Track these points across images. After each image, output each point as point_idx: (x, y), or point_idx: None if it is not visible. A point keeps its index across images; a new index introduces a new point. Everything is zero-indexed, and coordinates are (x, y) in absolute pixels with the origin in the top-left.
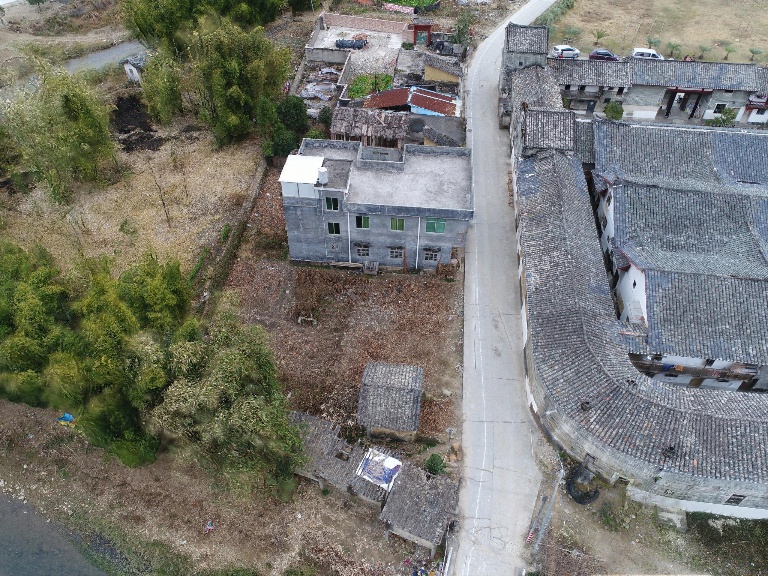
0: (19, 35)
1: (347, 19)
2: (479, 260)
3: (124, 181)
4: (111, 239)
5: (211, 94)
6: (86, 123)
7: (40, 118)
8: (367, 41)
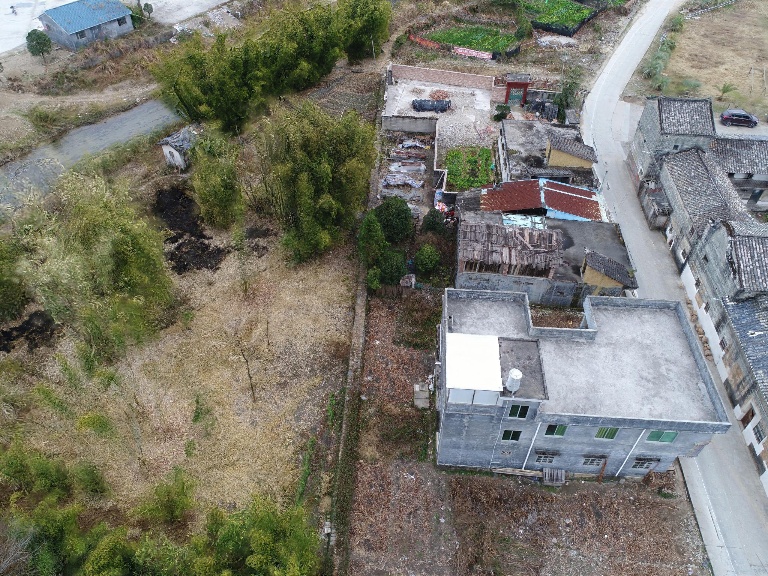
0: (21, 96)
1: (420, 71)
2: (699, 459)
3: (181, 322)
4: (177, 425)
5: (292, 203)
6: (138, 265)
7: (80, 276)
8: (448, 100)
